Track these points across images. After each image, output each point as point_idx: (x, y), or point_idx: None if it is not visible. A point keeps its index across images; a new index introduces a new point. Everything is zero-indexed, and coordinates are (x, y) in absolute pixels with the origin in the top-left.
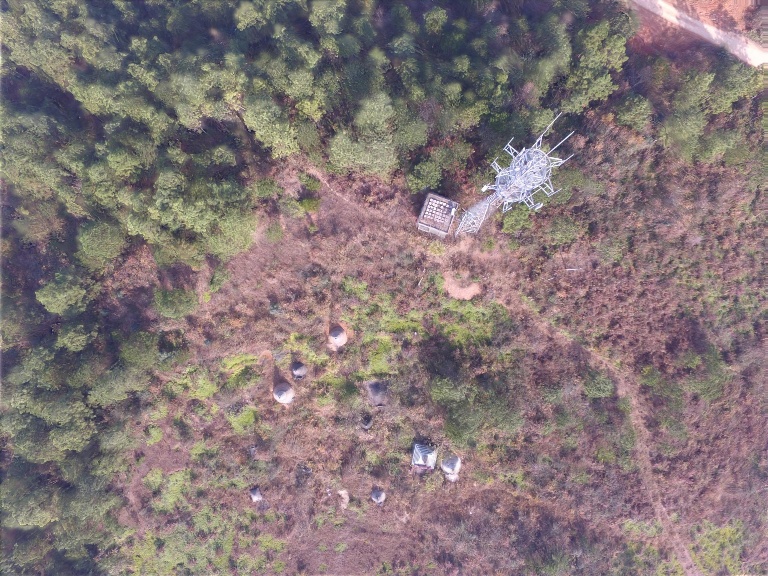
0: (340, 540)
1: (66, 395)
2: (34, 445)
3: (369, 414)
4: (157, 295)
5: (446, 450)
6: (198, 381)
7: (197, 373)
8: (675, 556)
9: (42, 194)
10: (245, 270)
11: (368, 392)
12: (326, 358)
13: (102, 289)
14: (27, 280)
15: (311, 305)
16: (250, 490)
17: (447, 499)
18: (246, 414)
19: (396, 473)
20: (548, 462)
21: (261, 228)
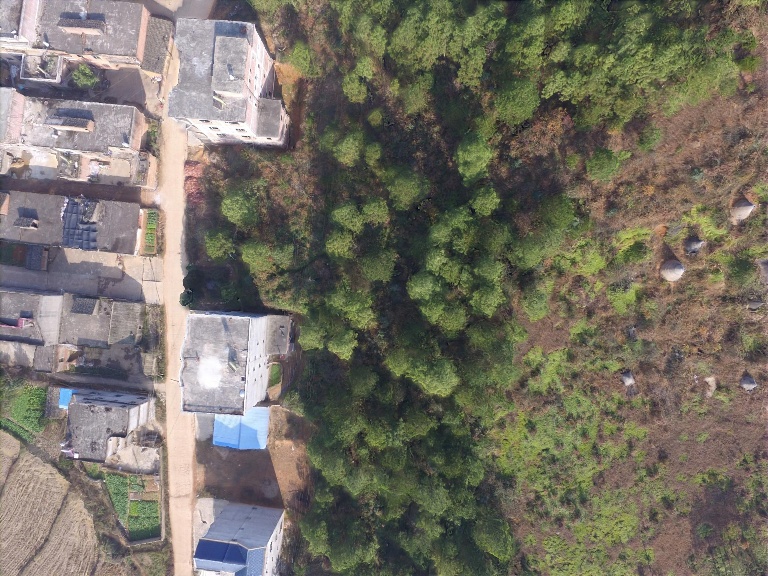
0: (702, 430)
1: (483, 257)
2: (452, 307)
3: (758, 293)
4: (570, 159)
5: None
6: (587, 256)
7: (588, 247)
8: None
9: (428, 63)
10: (667, 134)
11: (760, 270)
12: (722, 233)
13: (488, 161)
14: (385, 159)
15: (735, 170)
16: (622, 373)
17: None
18: (631, 292)
19: None
20: None
21: (688, 90)
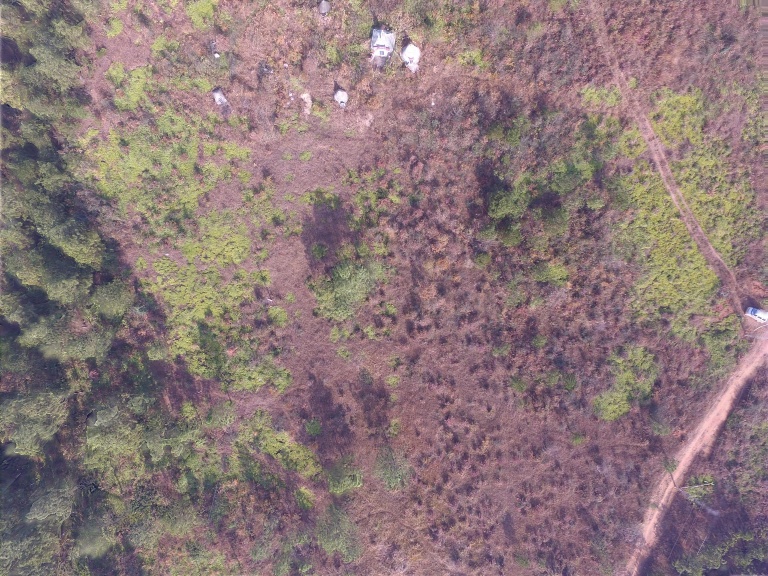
0: (305, 148)
1: None
2: None
3: None
4: None
5: (405, 38)
6: None
7: None
8: (636, 126)
9: None
10: None
11: None
12: None
13: None
14: None
15: None
16: (212, 91)
17: (408, 91)
18: (205, 4)
19: (356, 66)
20: (505, 36)
21: None
